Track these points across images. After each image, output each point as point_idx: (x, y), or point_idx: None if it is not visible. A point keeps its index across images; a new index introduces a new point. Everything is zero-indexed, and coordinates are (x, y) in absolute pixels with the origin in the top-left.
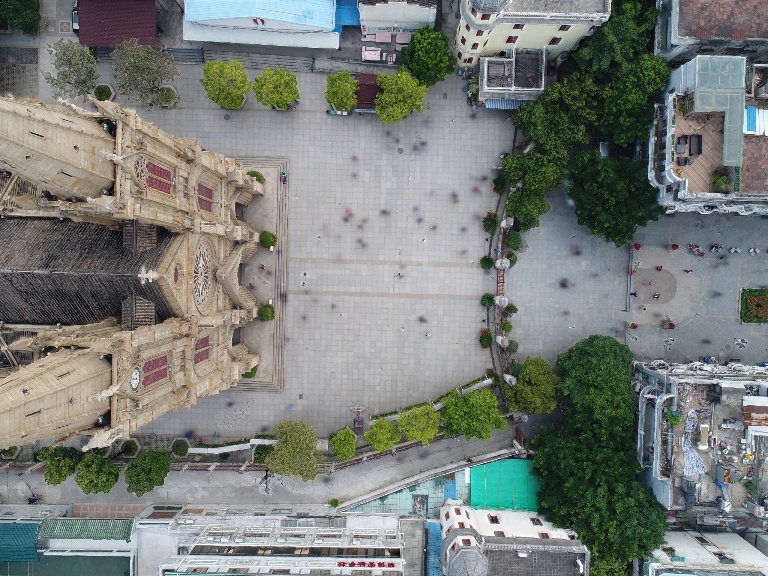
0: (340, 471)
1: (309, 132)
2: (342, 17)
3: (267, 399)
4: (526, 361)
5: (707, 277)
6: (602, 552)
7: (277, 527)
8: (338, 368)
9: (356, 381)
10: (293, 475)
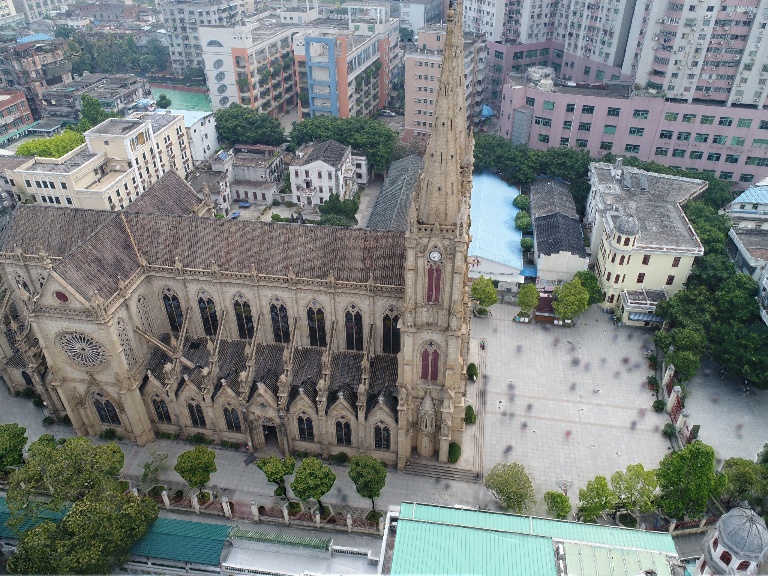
0: None
1: (500, 329)
2: (524, 273)
3: (466, 488)
4: None
5: None
6: None
7: None
8: (535, 470)
9: (555, 483)
10: None
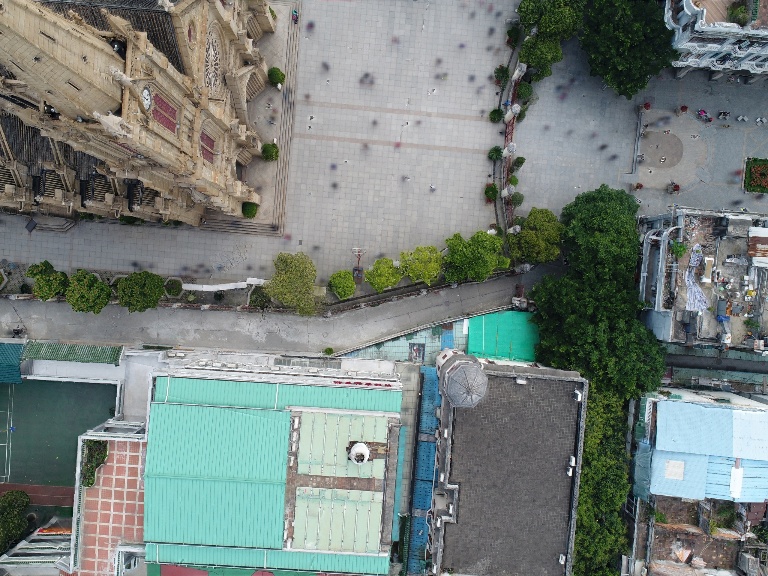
0: (336, 320)
1: None
2: None
3: (266, 243)
4: (531, 211)
5: (713, 144)
6: (600, 389)
7: (270, 364)
8: (340, 216)
9: (357, 230)
10: (288, 322)
